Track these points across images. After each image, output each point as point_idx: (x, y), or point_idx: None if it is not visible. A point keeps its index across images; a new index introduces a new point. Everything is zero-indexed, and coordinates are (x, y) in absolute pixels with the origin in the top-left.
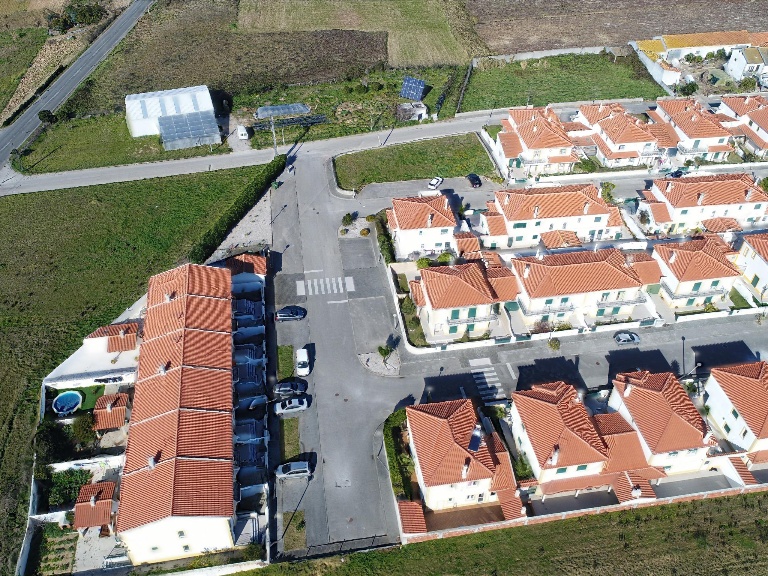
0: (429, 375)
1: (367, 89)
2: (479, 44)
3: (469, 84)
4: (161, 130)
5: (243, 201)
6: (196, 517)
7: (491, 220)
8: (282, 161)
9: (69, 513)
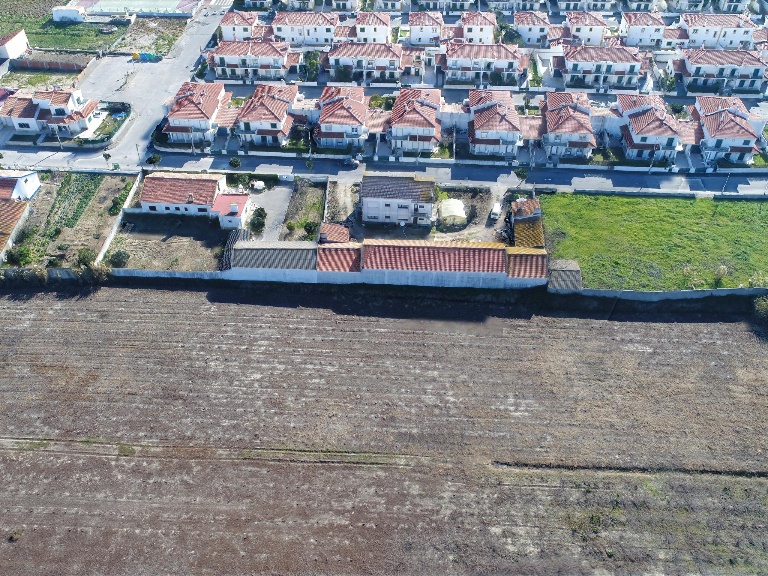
0: None
1: None
2: None
3: None
4: None
5: None
6: None
7: None
8: None
9: None
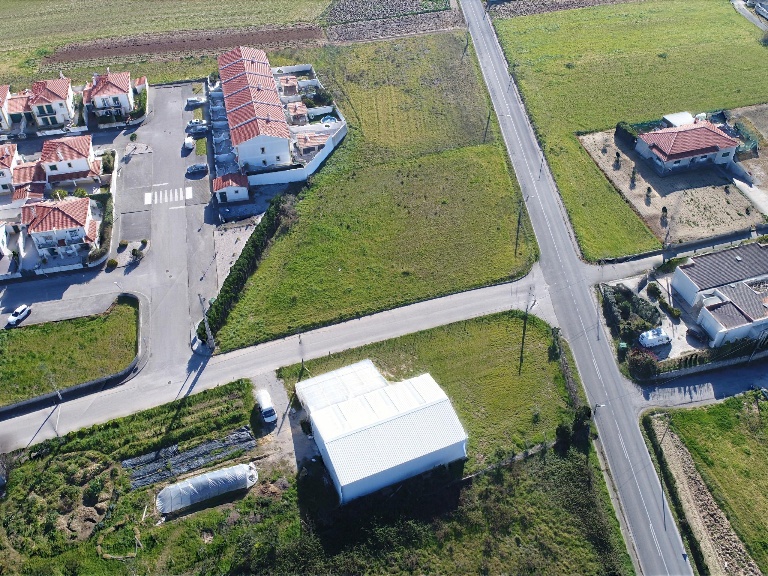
0: None
1: None
2: None
3: None
4: None
5: None
6: (231, 50)
7: None
8: None
9: (300, 80)
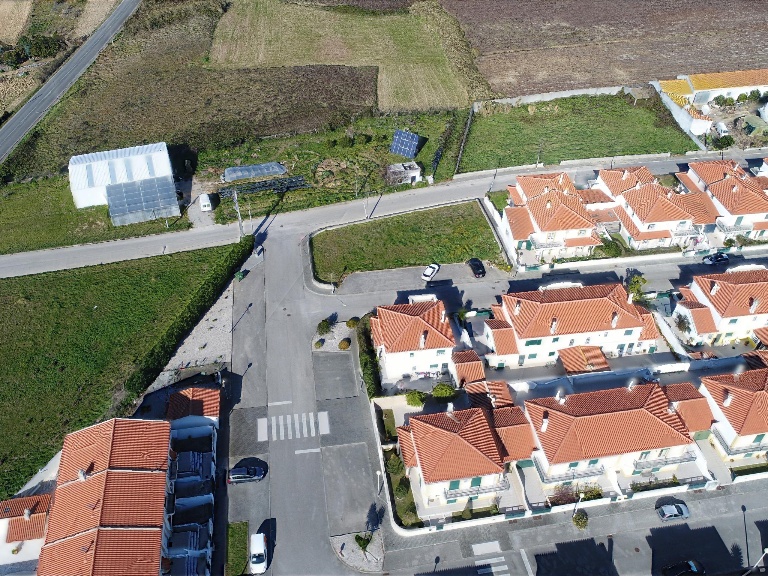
0: (421, 570)
1: (353, 142)
2: (481, 84)
3: (470, 134)
4: (109, 202)
5: (198, 303)
6: None
7: (498, 334)
8: (249, 244)
9: None
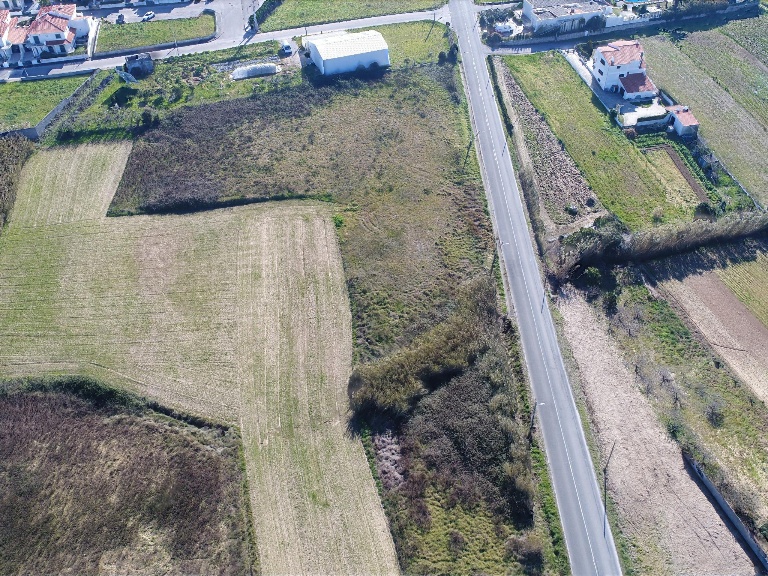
0: None
1: None
2: (5, 158)
3: None
4: None
5: None
6: None
7: None
8: None
9: None
